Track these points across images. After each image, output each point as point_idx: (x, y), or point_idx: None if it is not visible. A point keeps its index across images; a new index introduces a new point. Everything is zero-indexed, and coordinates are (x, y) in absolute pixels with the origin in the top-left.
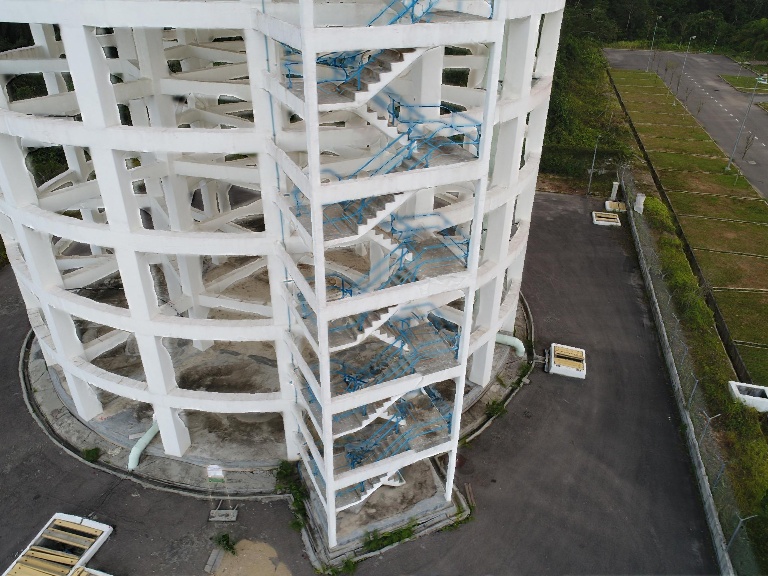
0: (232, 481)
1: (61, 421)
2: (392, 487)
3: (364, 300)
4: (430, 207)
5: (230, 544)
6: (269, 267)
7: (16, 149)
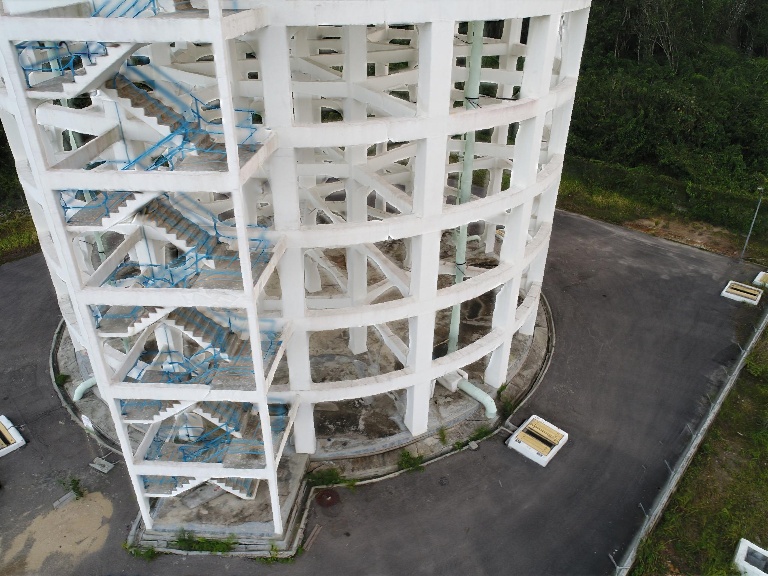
0: (131, 439)
1: (65, 346)
2: (238, 498)
3: (121, 293)
4: (293, 220)
5: (81, 490)
6: (136, 248)
7: None
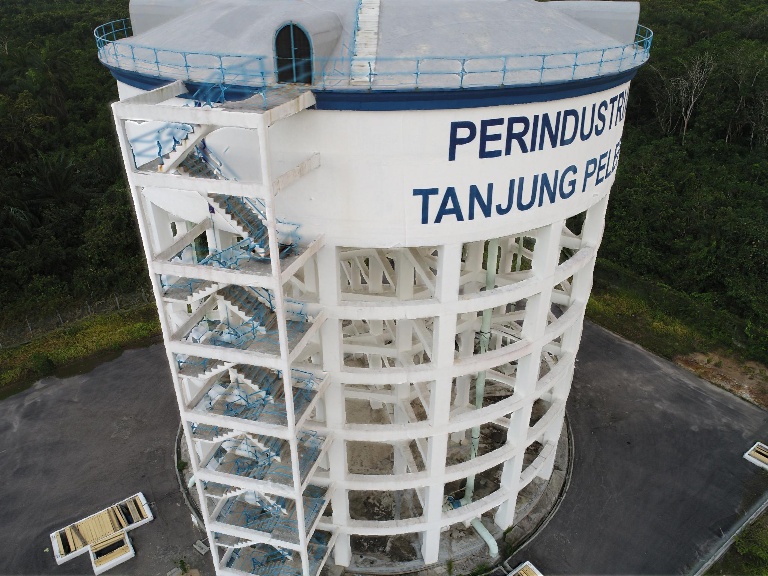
0: None
1: None
2: None
3: (220, 477)
4: (339, 423)
5: (186, 567)
6: None
7: None
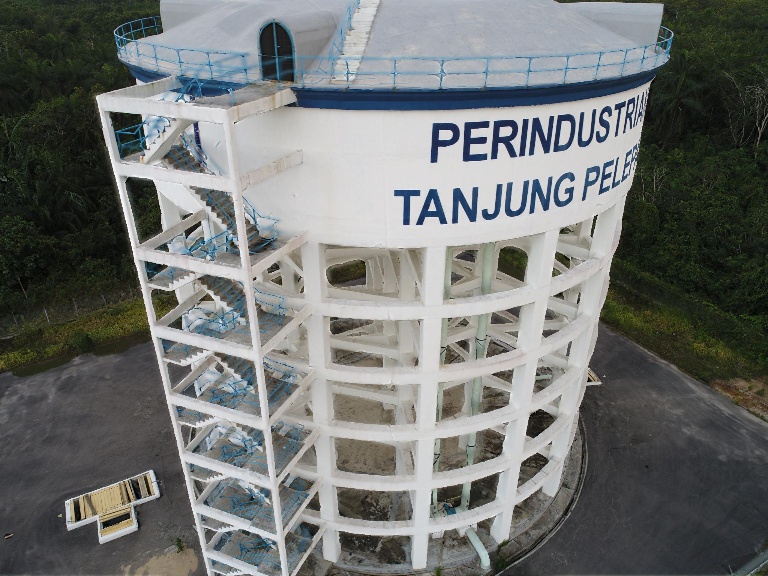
0: None
1: None
2: None
3: (203, 461)
4: (325, 419)
5: (182, 546)
6: None
7: None
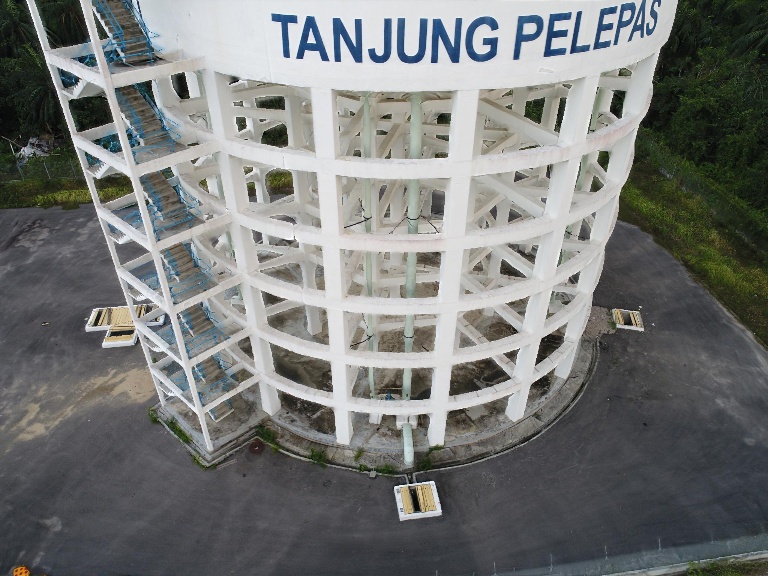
0: None
1: None
2: None
3: None
4: (245, 267)
5: None
6: None
7: None
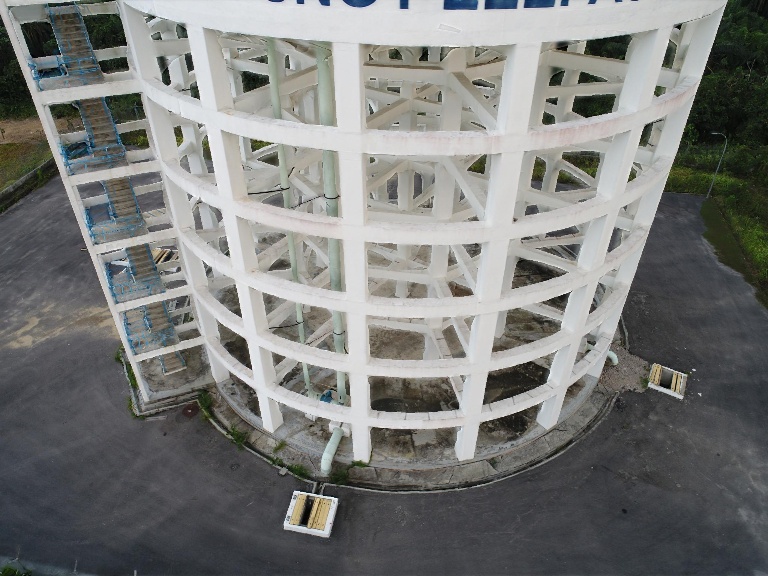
0: None
1: None
2: None
3: None
4: None
5: None
6: None
7: (233, 82)
